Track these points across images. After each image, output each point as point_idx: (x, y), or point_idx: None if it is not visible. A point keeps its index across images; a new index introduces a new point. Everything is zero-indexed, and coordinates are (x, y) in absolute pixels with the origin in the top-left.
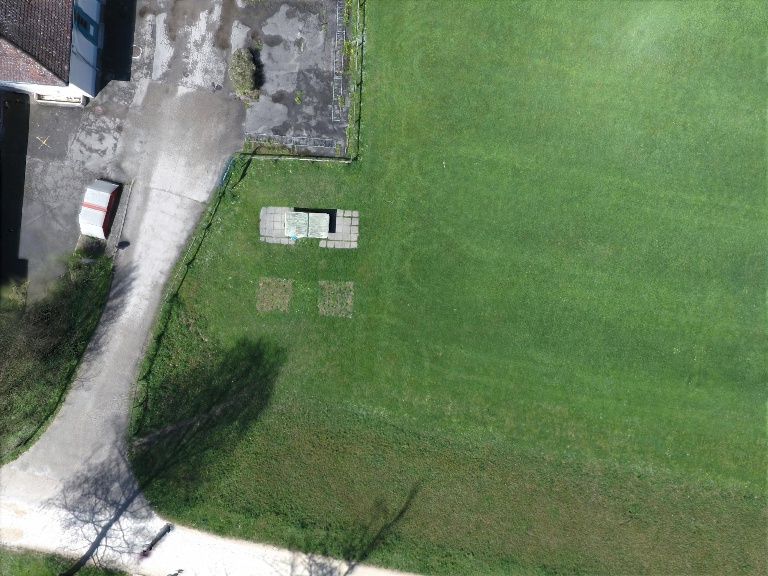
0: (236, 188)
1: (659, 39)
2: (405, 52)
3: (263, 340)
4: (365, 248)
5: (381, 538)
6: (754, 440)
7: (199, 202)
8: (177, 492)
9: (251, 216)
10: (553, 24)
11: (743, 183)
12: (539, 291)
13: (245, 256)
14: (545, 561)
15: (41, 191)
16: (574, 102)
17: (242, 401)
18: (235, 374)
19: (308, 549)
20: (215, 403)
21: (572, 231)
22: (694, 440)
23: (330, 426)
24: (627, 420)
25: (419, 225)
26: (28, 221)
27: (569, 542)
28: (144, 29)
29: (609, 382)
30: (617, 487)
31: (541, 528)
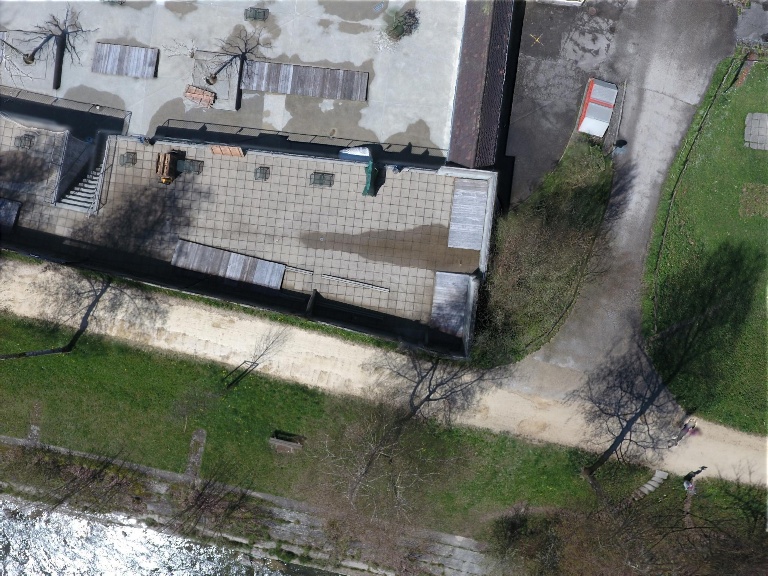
0: (728, 92)
1: None
2: None
3: (744, 246)
4: None
5: None
6: None
7: (691, 105)
8: (700, 387)
9: (738, 121)
10: None
11: None
12: None
13: (730, 161)
14: None
15: (531, 88)
16: None
17: (728, 305)
18: (718, 278)
19: None
20: (708, 305)
21: None
22: None
23: None
24: None
25: None
26: (517, 118)
27: None
28: None
29: None
30: None
31: None
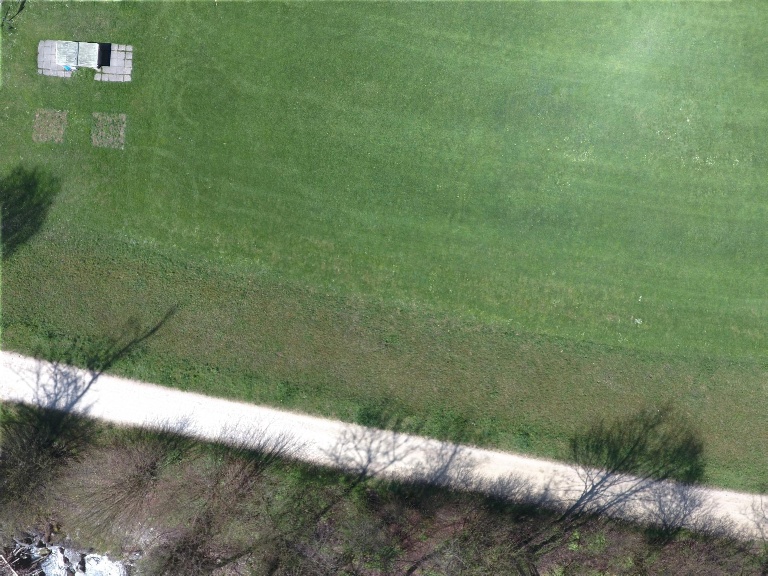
0: (13, 20)
1: None
2: None
3: (38, 170)
4: (138, 82)
5: (128, 351)
6: (516, 278)
7: None
8: None
9: (29, 49)
10: None
11: (503, 23)
12: (306, 127)
13: (22, 87)
14: (289, 379)
15: None
16: None
17: (13, 227)
18: (9, 201)
19: (53, 357)
20: None
21: (339, 69)
22: (457, 277)
23: (99, 254)
24: (392, 256)
25: (191, 60)
26: None
27: (317, 363)
28: None
29: (374, 218)
30: (378, 319)
31: (292, 350)
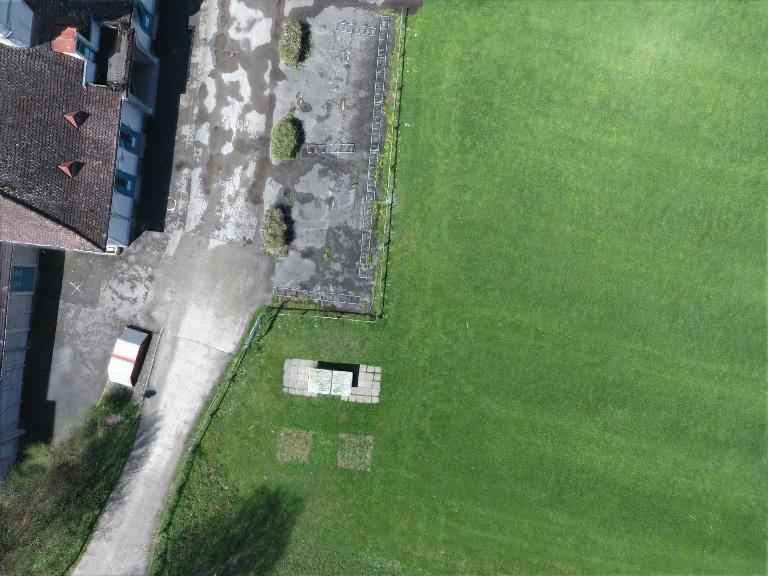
0: (262, 341)
1: (684, 212)
2: (433, 214)
3: (282, 489)
4: (386, 403)
5: None
6: None
7: (225, 353)
8: None
9: (275, 368)
10: (580, 193)
11: (764, 356)
12: (557, 453)
13: (268, 406)
14: None
15: (72, 335)
16: (598, 270)
17: (259, 550)
18: (253, 522)
19: None
20: (232, 553)
21: (592, 395)
22: None
23: None
24: None
25: (440, 383)
26: (58, 363)
27: None
28: (179, 182)
29: (624, 546)
30: None
31: None
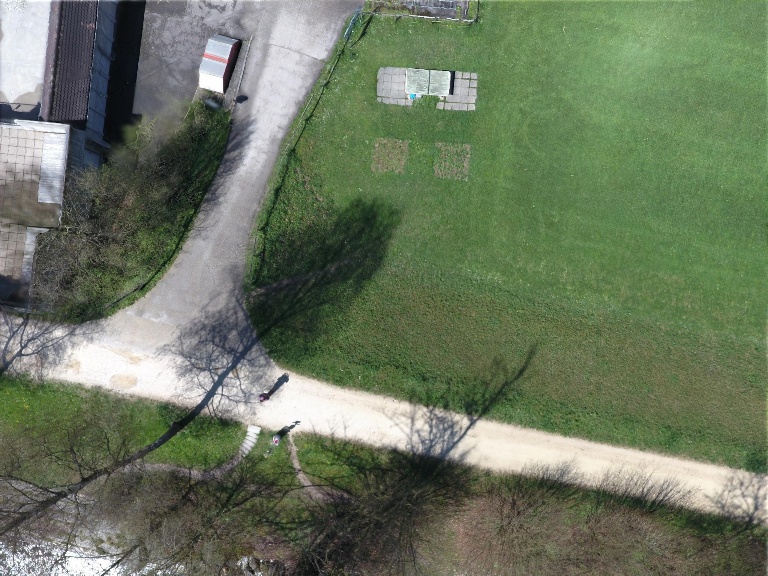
0: (355, 46)
1: None
2: None
3: (377, 202)
4: (483, 111)
5: (503, 394)
6: None
7: (318, 60)
8: (296, 341)
9: (369, 76)
10: None
11: None
12: (657, 158)
13: (362, 116)
14: (670, 422)
15: (158, 46)
16: None
17: (356, 261)
18: (348, 235)
19: (430, 402)
20: (330, 261)
21: (691, 98)
22: None
23: (444, 290)
24: (744, 292)
25: (537, 89)
26: (144, 76)
27: (692, 406)
28: None
29: (726, 253)
30: (735, 358)
31: (663, 392)
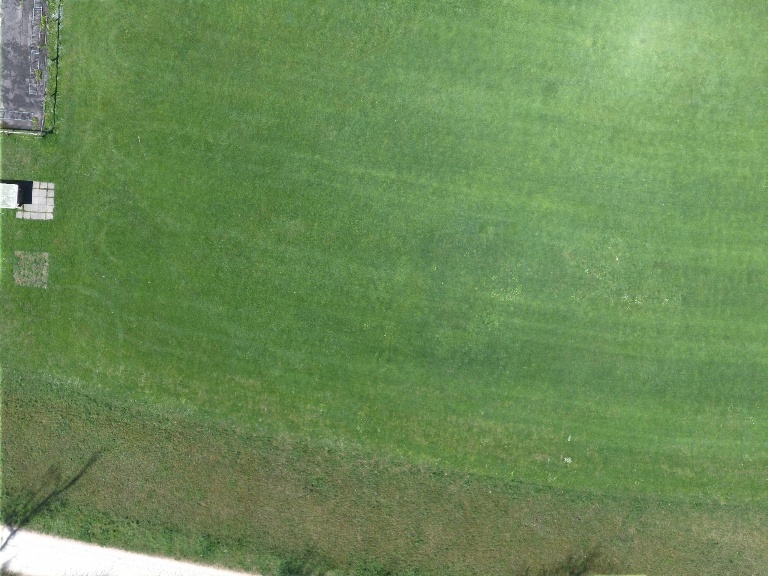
0: None
1: (347, 19)
2: (100, 28)
3: None
4: (60, 220)
5: (46, 504)
6: (445, 417)
7: None
8: None
9: None
10: (244, 3)
11: (430, 161)
12: (232, 265)
13: None
14: (211, 531)
15: None
16: (265, 79)
17: None
18: None
19: None
20: None
21: (264, 206)
22: (385, 416)
23: (22, 395)
24: (319, 395)
25: (114, 198)
26: None
27: (240, 513)
28: None
29: (301, 357)
30: (304, 461)
31: (215, 499)
